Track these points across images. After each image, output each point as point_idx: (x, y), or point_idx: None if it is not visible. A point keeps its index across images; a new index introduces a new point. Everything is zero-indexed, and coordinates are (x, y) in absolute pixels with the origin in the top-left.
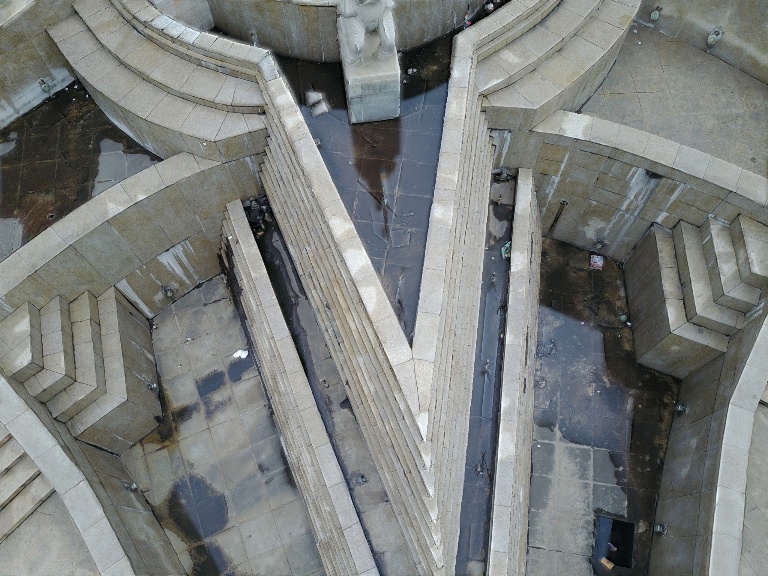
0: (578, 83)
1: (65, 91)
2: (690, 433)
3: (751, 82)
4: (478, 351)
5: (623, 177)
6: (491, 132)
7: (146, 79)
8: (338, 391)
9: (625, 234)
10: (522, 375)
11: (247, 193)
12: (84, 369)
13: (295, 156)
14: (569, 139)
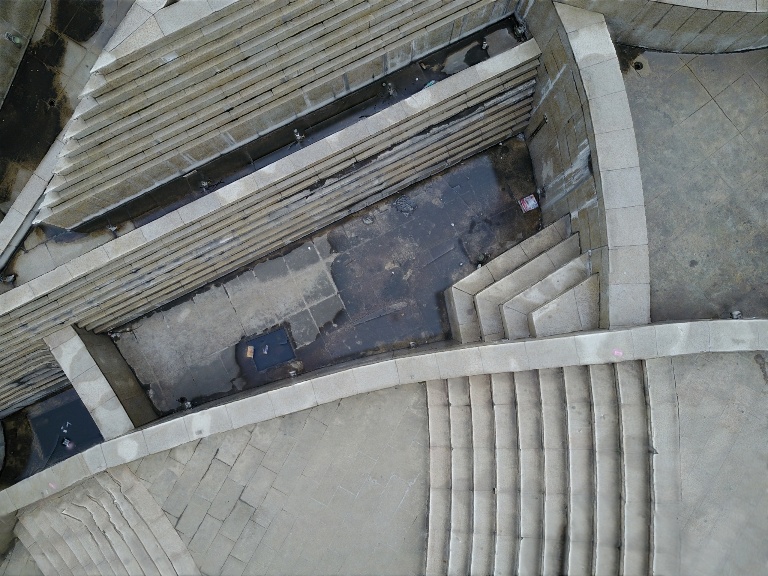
0: (642, 7)
1: None
2: (381, 356)
3: None
4: (312, 123)
5: (579, 141)
6: None
7: None
8: None
9: (556, 202)
10: (319, 176)
11: None
12: None
13: None
14: None
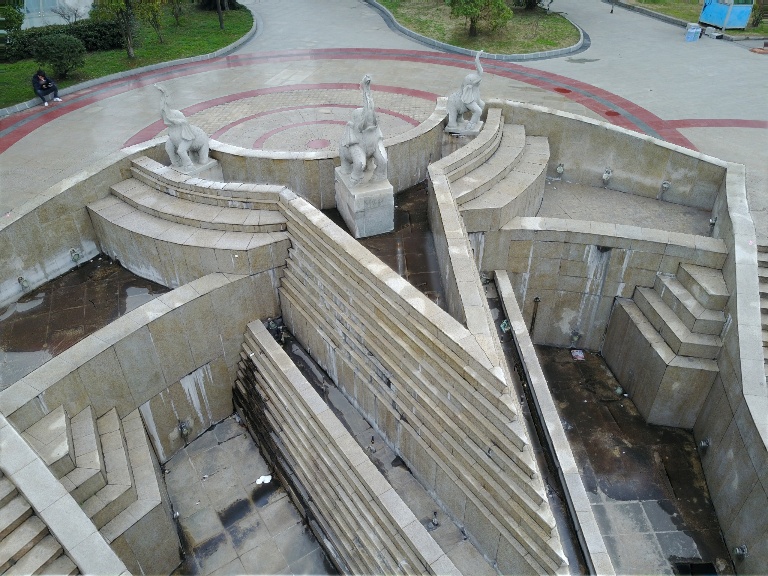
0: (525, 196)
1: (90, 262)
2: (722, 451)
3: (645, 199)
4: None
5: (580, 258)
6: (468, 236)
7: (180, 222)
8: (386, 453)
9: (595, 318)
10: None
11: (266, 313)
12: (116, 472)
13: (323, 240)
14: (531, 232)
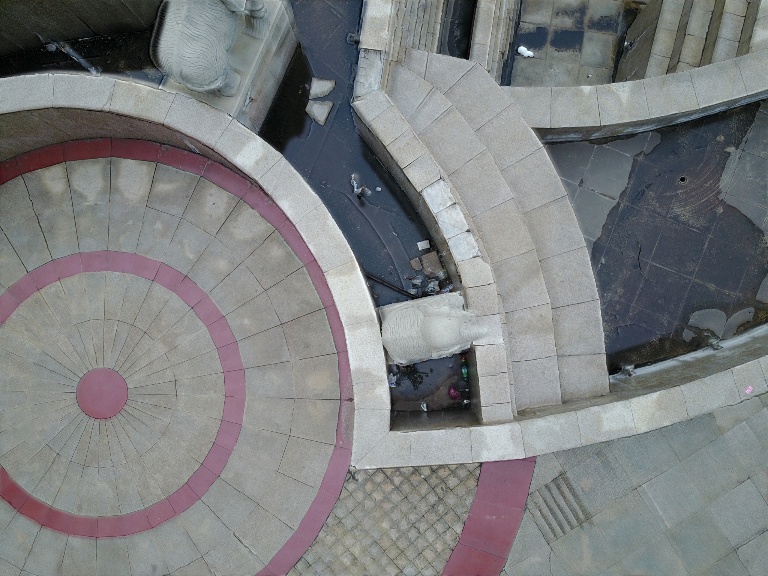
0: None
1: None
2: None
3: None
4: None
5: None
6: None
7: None
8: None
9: None
10: None
11: None
12: (705, 6)
13: None
14: None
